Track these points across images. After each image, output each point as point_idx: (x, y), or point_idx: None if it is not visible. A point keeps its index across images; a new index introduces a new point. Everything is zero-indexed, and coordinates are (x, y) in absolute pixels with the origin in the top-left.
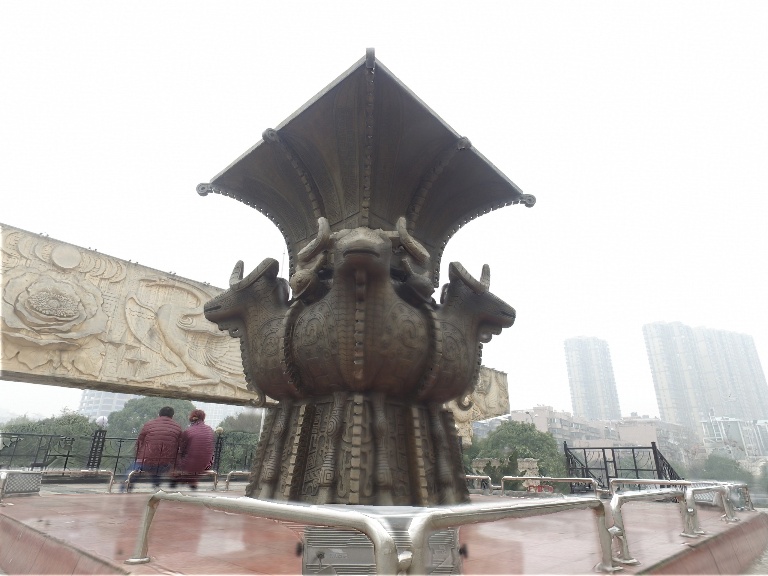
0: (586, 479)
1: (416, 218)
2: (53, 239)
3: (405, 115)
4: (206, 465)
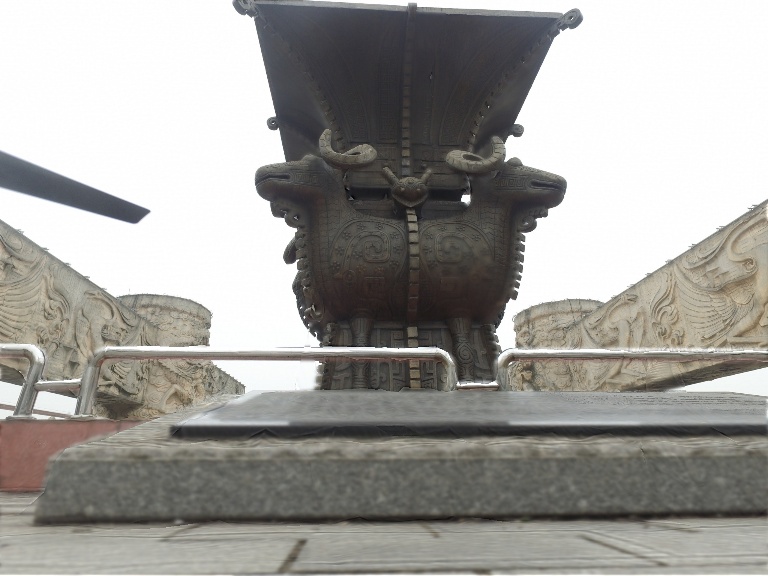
0: (129, 349)
1: None
2: None
3: None
4: None
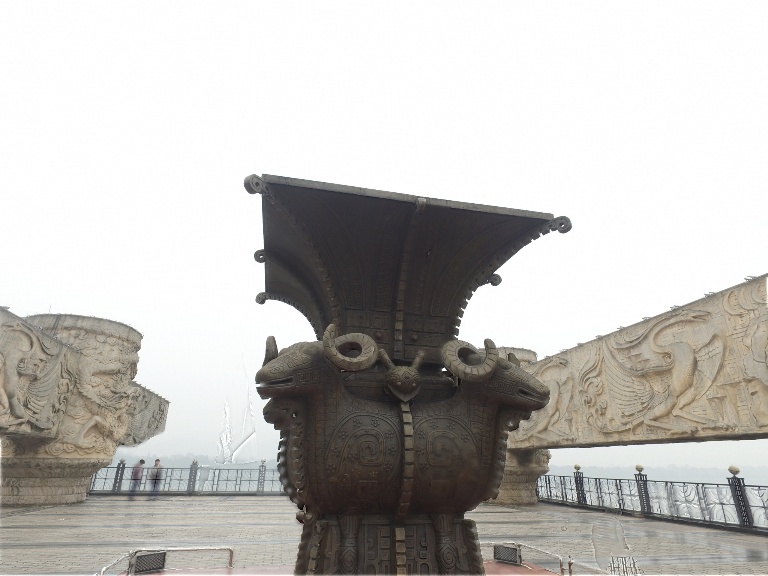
0: None
1: (318, 313)
2: (761, 277)
3: (278, 281)
4: (607, 568)
